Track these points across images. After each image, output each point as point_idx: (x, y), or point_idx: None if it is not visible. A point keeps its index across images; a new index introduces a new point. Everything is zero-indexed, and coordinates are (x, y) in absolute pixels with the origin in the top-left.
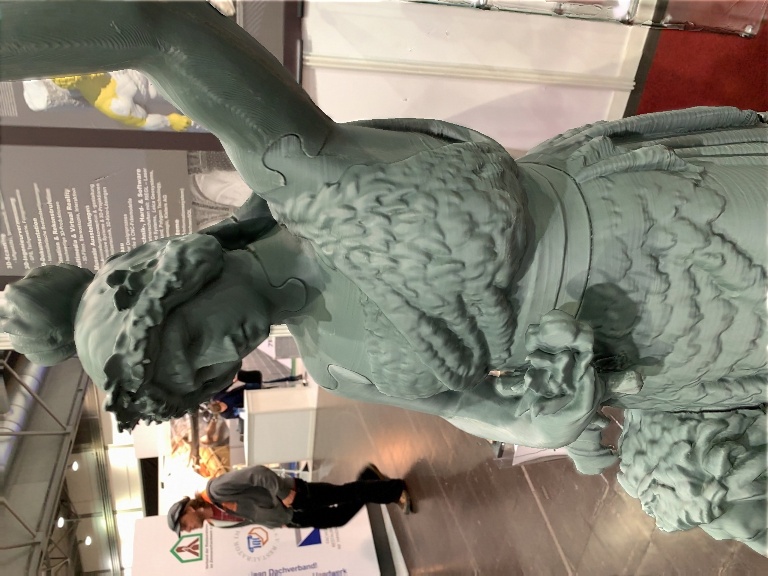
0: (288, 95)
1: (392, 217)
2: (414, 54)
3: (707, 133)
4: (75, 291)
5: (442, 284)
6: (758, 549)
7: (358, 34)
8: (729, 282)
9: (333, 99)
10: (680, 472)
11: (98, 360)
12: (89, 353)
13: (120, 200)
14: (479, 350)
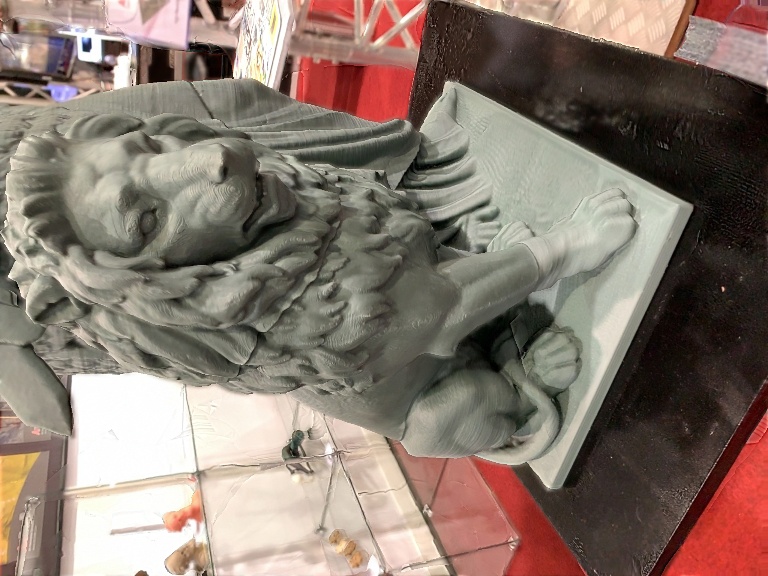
0: None
1: None
2: None
3: None
4: None
5: None
6: (165, 164)
7: None
8: (21, 111)
9: None
10: None
11: None
12: None
13: None
14: None
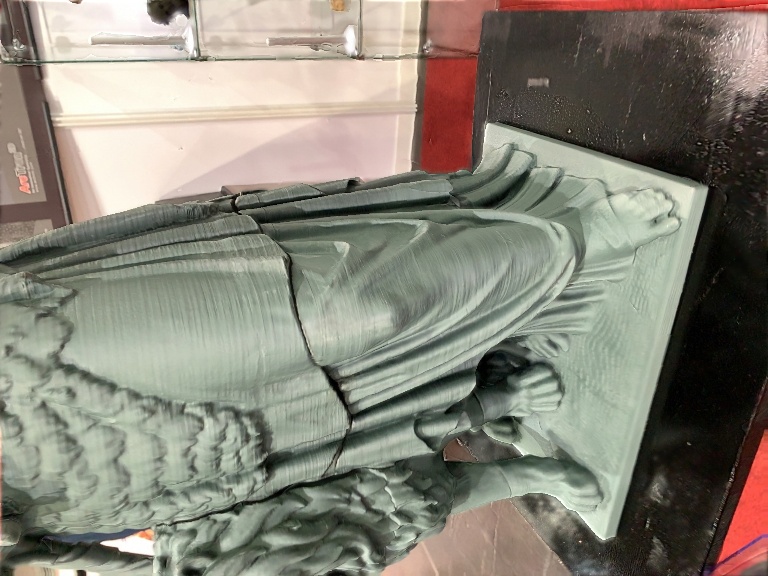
0: None
1: None
2: (178, 102)
3: (129, 239)
4: None
5: None
6: None
7: (110, 89)
8: (95, 411)
9: (98, 157)
10: None
11: None
12: None
13: None
14: None
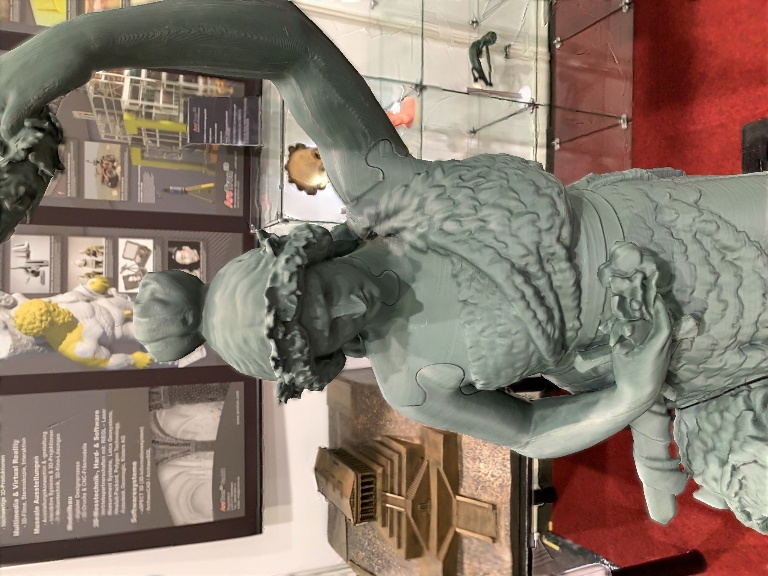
0: (382, 112)
1: (474, 188)
2: None
3: None
4: (201, 284)
5: (524, 234)
6: None
7: None
8: (727, 244)
9: None
10: (754, 440)
11: (248, 305)
12: (237, 304)
13: (74, 446)
14: (558, 312)
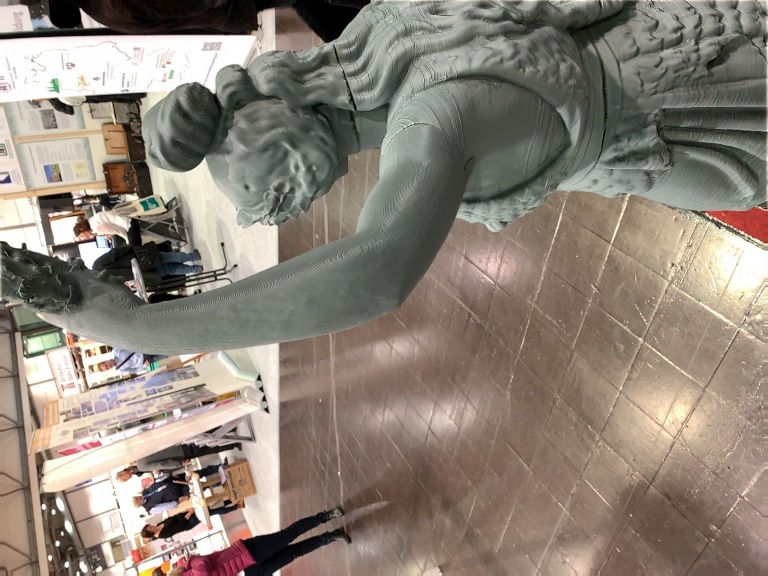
0: None
1: None
2: None
3: (732, 119)
4: None
5: None
6: None
7: None
8: None
9: None
10: None
11: None
12: None
13: None
14: None
